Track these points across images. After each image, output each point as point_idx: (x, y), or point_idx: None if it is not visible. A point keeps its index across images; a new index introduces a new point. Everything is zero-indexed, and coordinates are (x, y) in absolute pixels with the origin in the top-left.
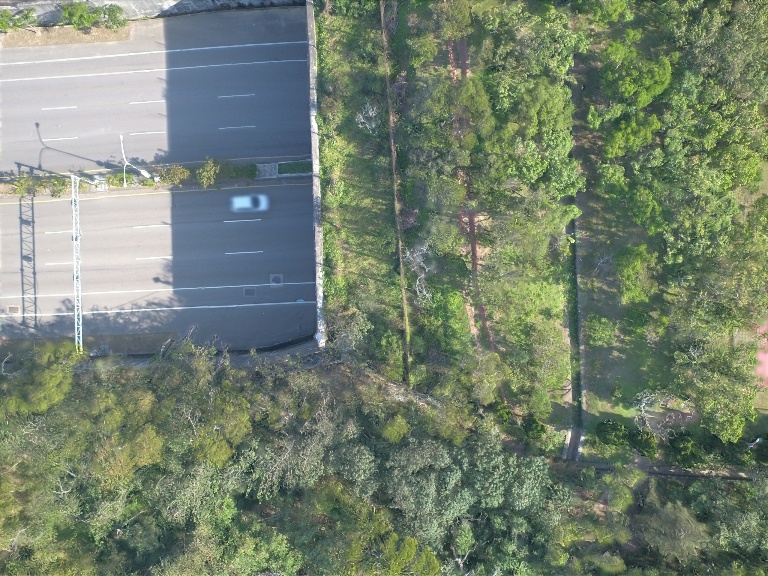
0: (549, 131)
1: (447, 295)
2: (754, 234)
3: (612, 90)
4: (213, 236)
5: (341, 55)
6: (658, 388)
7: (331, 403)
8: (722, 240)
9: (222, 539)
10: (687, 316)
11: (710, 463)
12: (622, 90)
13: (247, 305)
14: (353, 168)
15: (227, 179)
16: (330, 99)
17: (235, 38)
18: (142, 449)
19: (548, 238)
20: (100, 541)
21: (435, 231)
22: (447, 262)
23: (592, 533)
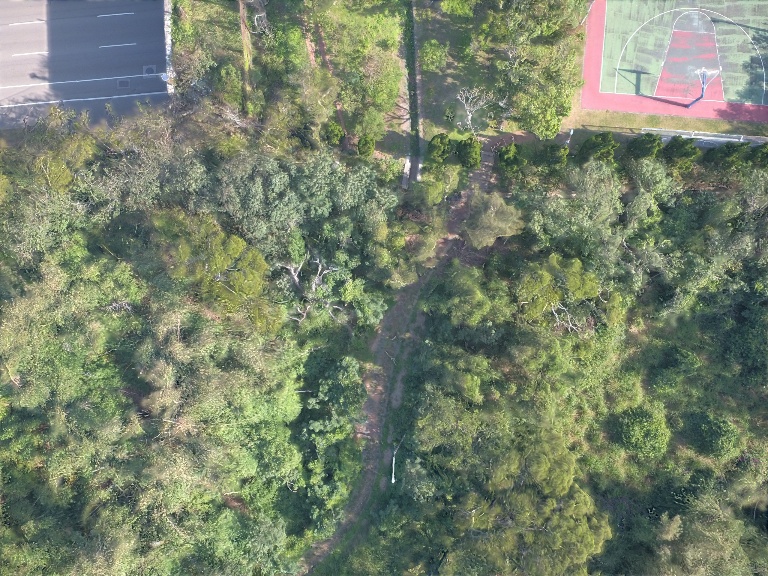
0: None
1: (288, 32)
2: None
3: None
4: (87, 31)
5: None
6: (476, 85)
7: (171, 131)
8: None
9: (71, 275)
10: (505, 19)
11: (544, 185)
12: None
13: (121, 96)
14: None
15: None
16: None
17: None
18: None
19: None
20: None
21: None
22: None
23: (432, 259)
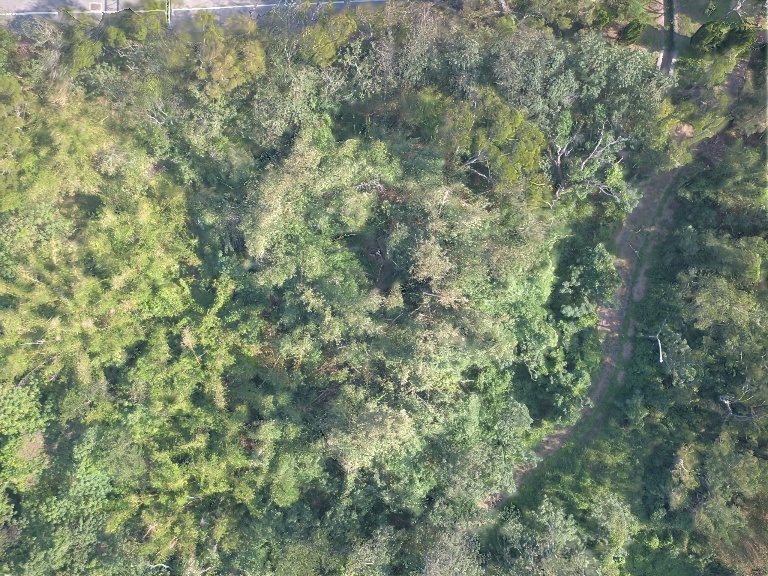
0: None
1: None
2: None
3: None
4: None
5: None
6: None
7: (432, 12)
8: None
9: (318, 154)
10: None
11: None
12: None
13: None
14: None
15: None
16: None
17: None
18: (242, 62)
19: None
20: (189, 180)
21: None
22: None
23: None
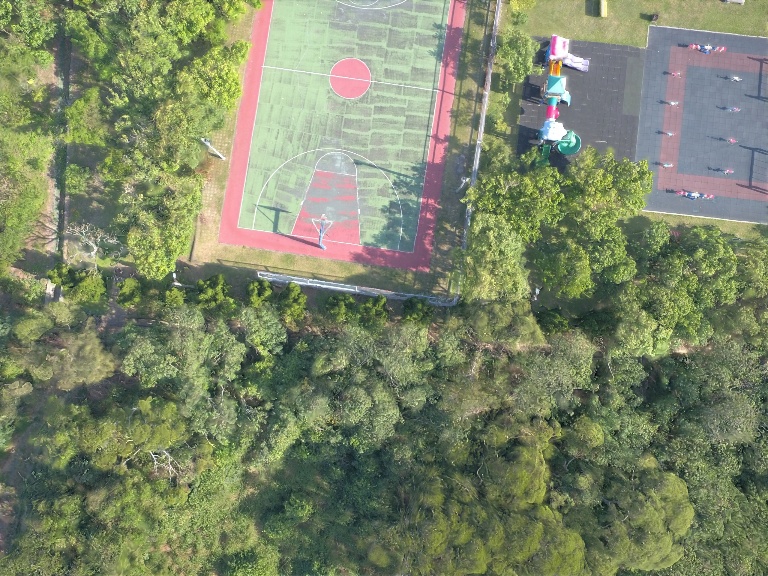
0: None
1: None
2: None
3: None
4: None
5: None
6: (83, 221)
7: None
8: (156, 80)
9: None
10: None
11: None
12: None
13: None
14: None
15: None
16: None
17: None
18: None
19: None
20: None
21: None
22: None
23: (68, 382)
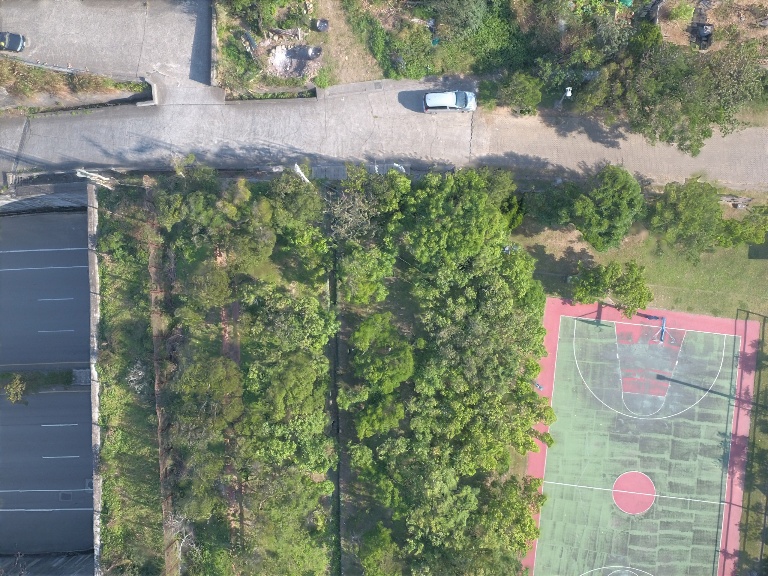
0: (294, 417)
1: (214, 553)
2: (489, 530)
3: (362, 371)
4: (31, 439)
5: (122, 302)
6: None
7: None
8: (457, 535)
9: None
10: None
11: None
12: (366, 379)
13: (63, 509)
14: (131, 417)
15: (37, 392)
16: (106, 351)
17: (55, 241)
18: None
19: (291, 525)
20: None
21: (186, 509)
22: (214, 521)
23: None
